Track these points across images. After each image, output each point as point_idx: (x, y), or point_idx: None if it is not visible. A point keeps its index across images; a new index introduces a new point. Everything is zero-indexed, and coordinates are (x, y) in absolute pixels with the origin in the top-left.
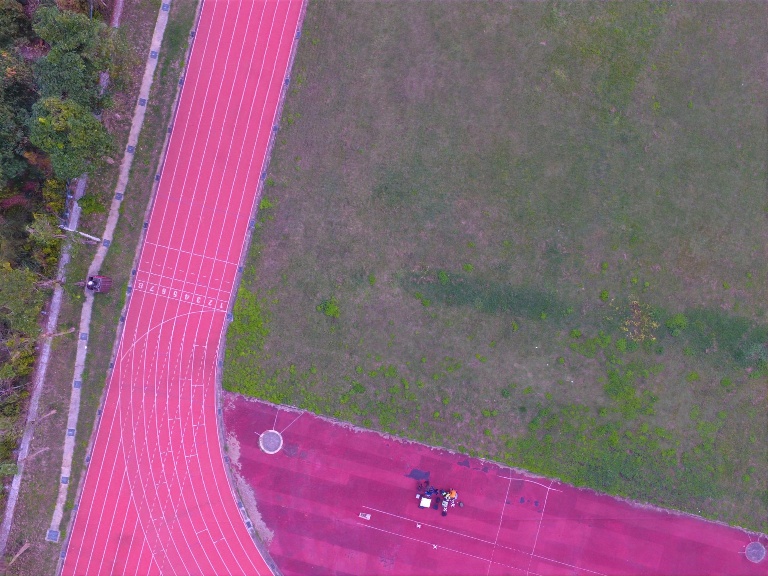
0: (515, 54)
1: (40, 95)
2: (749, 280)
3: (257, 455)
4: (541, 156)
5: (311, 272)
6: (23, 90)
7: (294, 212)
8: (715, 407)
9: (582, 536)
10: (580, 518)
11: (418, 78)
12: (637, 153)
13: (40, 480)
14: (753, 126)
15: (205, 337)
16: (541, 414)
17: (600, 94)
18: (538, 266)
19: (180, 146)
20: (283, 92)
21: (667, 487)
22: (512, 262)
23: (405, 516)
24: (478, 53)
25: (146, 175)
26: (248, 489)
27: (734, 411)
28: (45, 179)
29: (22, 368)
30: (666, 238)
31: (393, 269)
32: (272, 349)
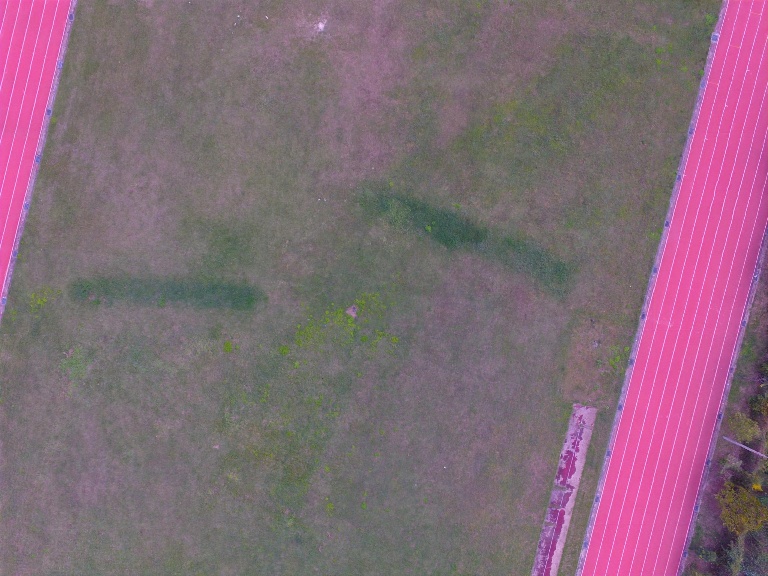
0: (187, 458)
1: None
2: None
3: None
4: (215, 558)
5: None
6: None
7: None
8: None
9: None
10: None
11: (90, 483)
12: (311, 554)
13: None
14: (426, 526)
15: None
16: None
17: (274, 496)
18: None
19: None
20: None
21: None
22: None
23: None
24: (150, 458)
25: None
26: None
27: None
28: None
29: None
30: None
31: None
32: None
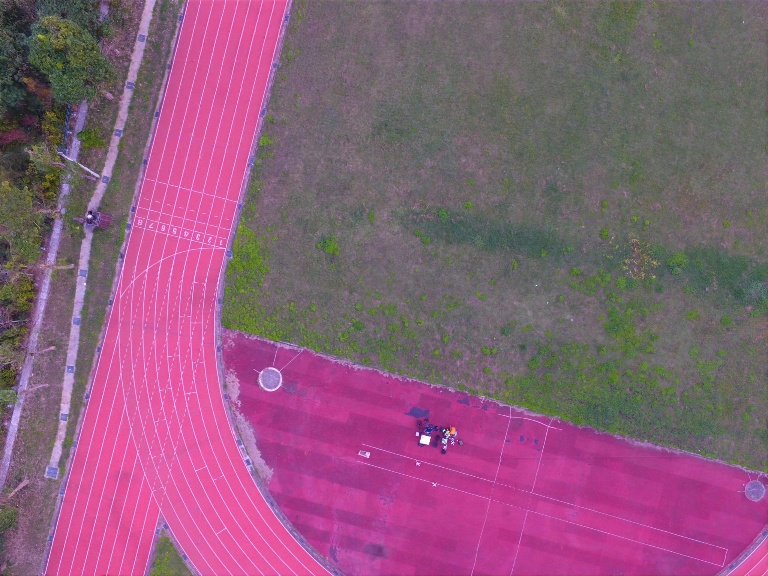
0: None
1: (39, 15)
2: (749, 218)
3: (256, 393)
4: (541, 93)
5: (311, 209)
6: (22, 16)
7: (294, 149)
8: (715, 346)
9: (582, 474)
10: (580, 456)
11: (418, 15)
12: (637, 91)
13: (39, 417)
14: (754, 64)
15: (204, 274)
16: (541, 352)
17: (600, 31)
18: (538, 204)
19: (179, 82)
20: (283, 29)
21: (667, 425)
22: (512, 200)
23: (405, 454)
24: None
25: (145, 111)
26: (247, 427)
27: (734, 350)
28: (44, 111)
29: (21, 301)
30: (666, 176)
31: (393, 207)
32: (272, 286)
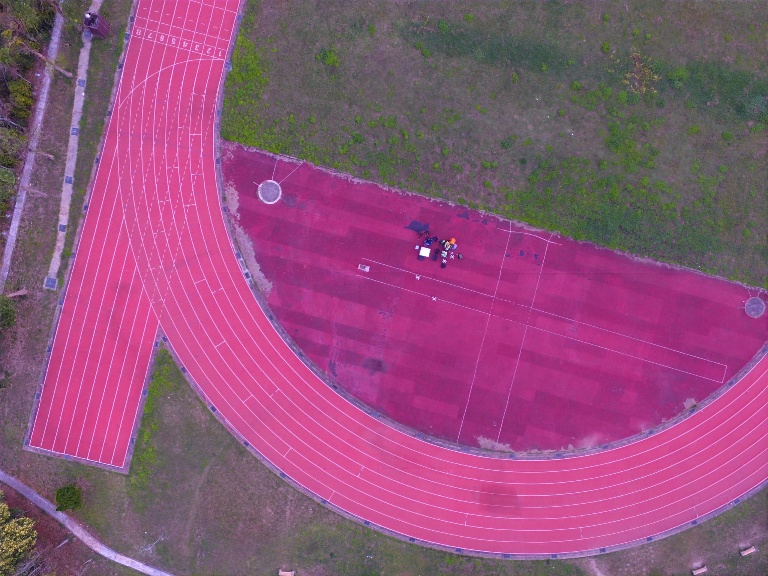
0: None
1: None
2: (751, 33)
3: (256, 205)
4: None
5: (310, 21)
6: None
7: None
8: (716, 161)
9: (581, 290)
10: (580, 271)
11: None
12: None
13: (38, 227)
14: None
15: (203, 85)
16: (541, 165)
17: None
18: (539, 17)
19: None
20: None
21: (667, 241)
22: (513, 13)
23: (404, 268)
24: None
25: None
26: (247, 240)
27: (735, 165)
28: None
29: (19, 100)
30: None
31: (393, 19)
32: (271, 98)
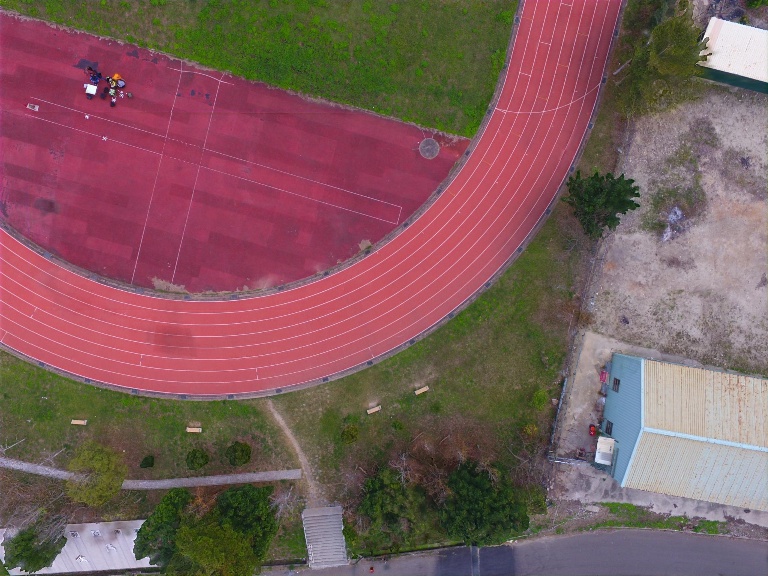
0: None
1: None
2: None
3: None
4: None
5: None
6: None
7: None
8: (388, 0)
9: (254, 130)
10: (252, 111)
11: None
12: None
13: None
14: None
15: None
16: (210, 3)
17: None
18: None
19: None
20: None
21: (340, 81)
22: None
23: (74, 107)
24: None
25: None
26: None
27: (408, 4)
28: None
29: None
30: None
31: None
32: None
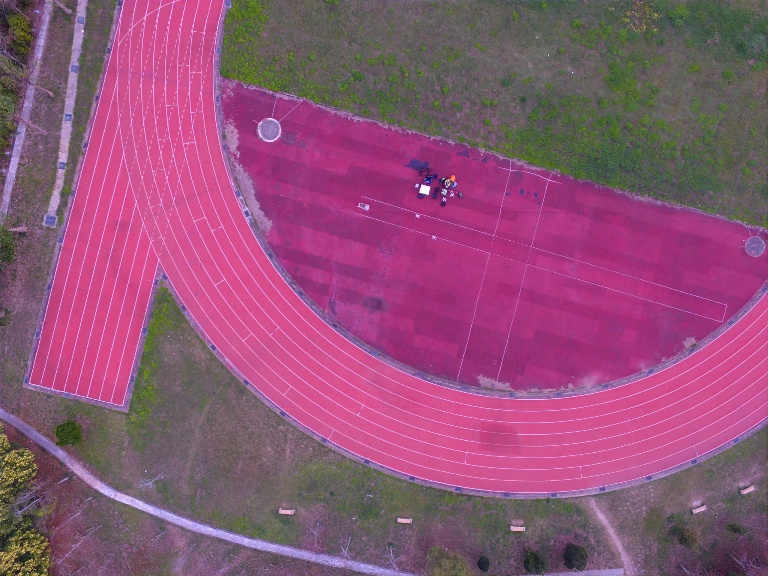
0: None
1: None
2: None
3: (255, 143)
4: None
5: None
6: None
7: None
8: (716, 99)
9: (581, 228)
10: (580, 210)
11: None
12: None
13: (37, 164)
14: None
15: (203, 23)
16: (541, 103)
17: None
18: None
19: None
20: None
21: (667, 180)
22: None
23: (404, 207)
24: None
25: None
26: (246, 178)
27: (735, 104)
28: None
29: (18, 34)
30: None
31: None
32: (271, 36)
